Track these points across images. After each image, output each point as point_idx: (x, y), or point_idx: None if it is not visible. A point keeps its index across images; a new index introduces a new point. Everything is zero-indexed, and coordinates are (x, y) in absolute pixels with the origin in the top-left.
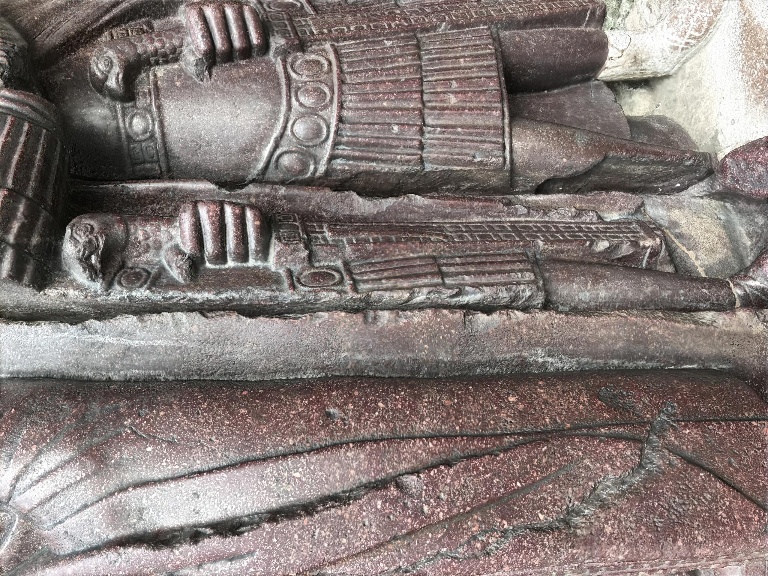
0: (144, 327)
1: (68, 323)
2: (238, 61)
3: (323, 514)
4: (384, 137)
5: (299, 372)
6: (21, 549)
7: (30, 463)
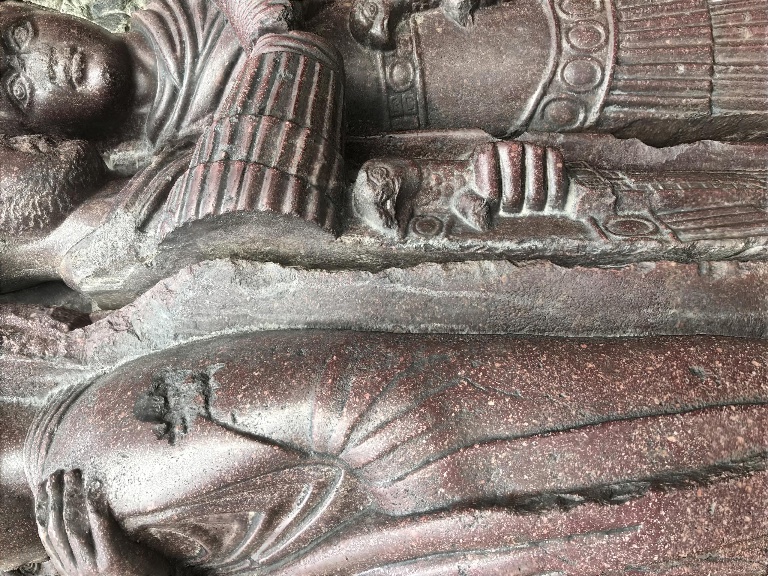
0: (449, 276)
1: (369, 271)
2: (501, 3)
3: (720, 485)
4: (667, 79)
5: (618, 330)
6: (343, 508)
7: (365, 412)
